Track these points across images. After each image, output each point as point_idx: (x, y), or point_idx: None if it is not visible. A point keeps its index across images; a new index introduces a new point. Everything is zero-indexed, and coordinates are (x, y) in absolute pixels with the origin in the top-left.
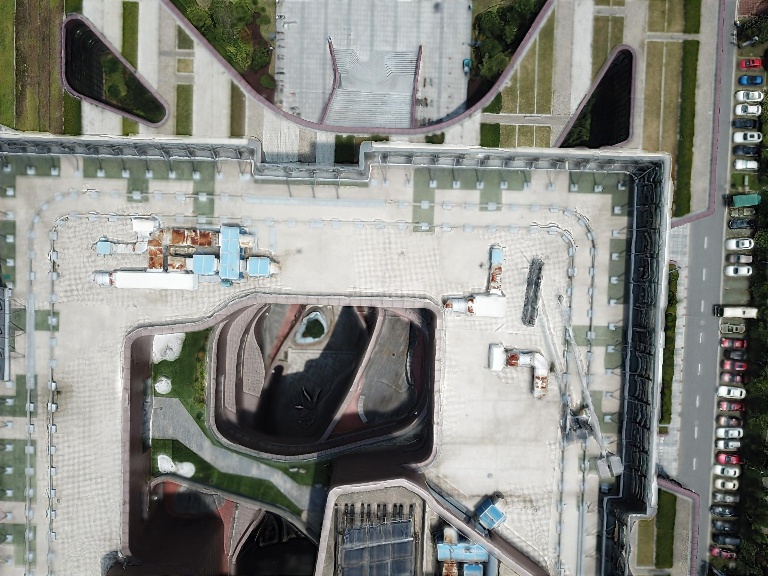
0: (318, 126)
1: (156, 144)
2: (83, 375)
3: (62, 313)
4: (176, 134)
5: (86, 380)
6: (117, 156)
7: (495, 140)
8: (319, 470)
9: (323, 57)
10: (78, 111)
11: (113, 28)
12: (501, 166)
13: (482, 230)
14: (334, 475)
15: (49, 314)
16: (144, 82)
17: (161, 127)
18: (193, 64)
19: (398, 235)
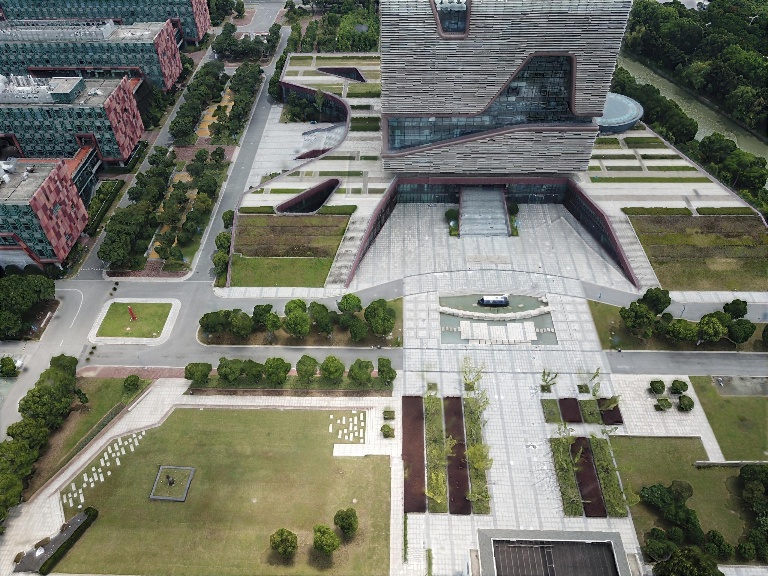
0: (344, 136)
1: None
2: None
3: None
4: (346, 176)
5: None
6: None
7: (354, 93)
8: None
9: (303, 161)
10: (330, 206)
11: (284, 197)
12: None
13: None
14: None
15: (442, 7)
16: (316, 186)
17: None
18: (308, 171)
19: None
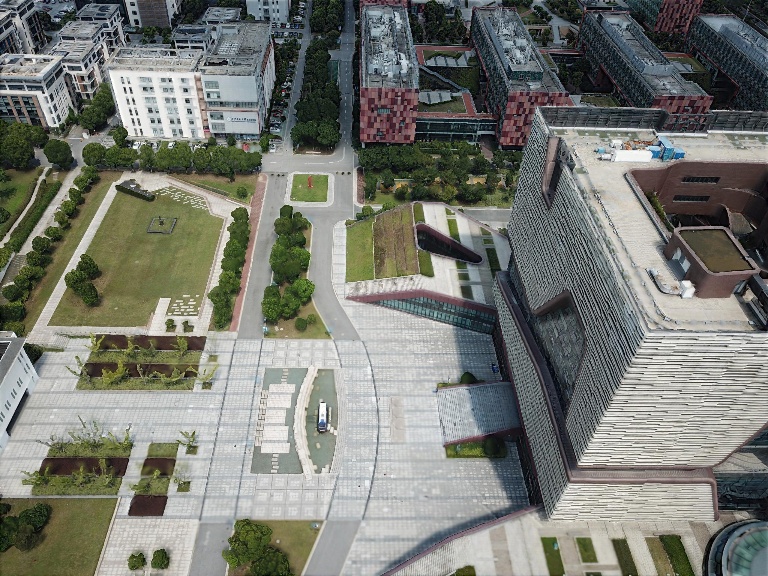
0: None
1: (622, 111)
2: (608, 187)
3: (588, 169)
4: (490, 268)
5: (610, 188)
6: (593, 129)
7: None
8: (744, 244)
9: None
10: (429, 257)
11: (443, 228)
12: (762, 131)
13: None
14: None
15: None
16: (466, 247)
17: (480, 265)
18: (493, 241)
19: (731, 150)
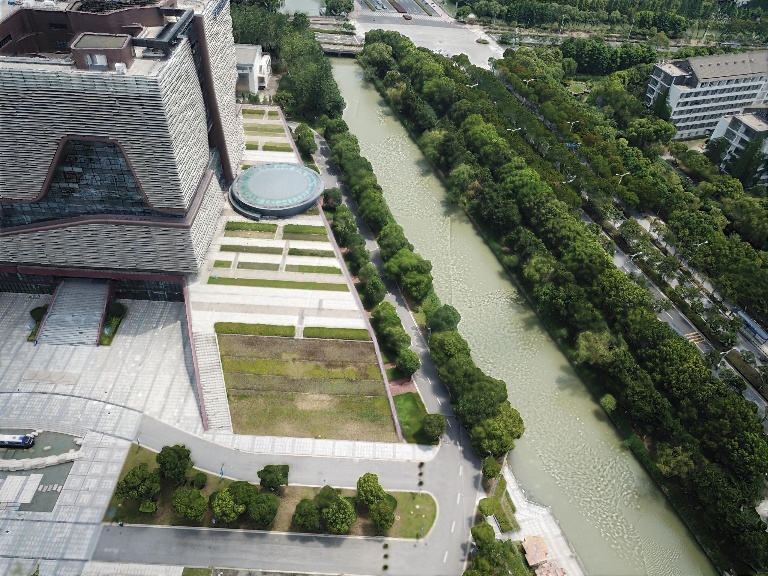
0: None
1: None
2: None
3: None
4: None
5: None
6: None
7: None
8: None
9: None
10: None
11: None
12: None
13: (1, 5)
14: (72, 28)
15: None
16: None
17: None
18: None
19: None
